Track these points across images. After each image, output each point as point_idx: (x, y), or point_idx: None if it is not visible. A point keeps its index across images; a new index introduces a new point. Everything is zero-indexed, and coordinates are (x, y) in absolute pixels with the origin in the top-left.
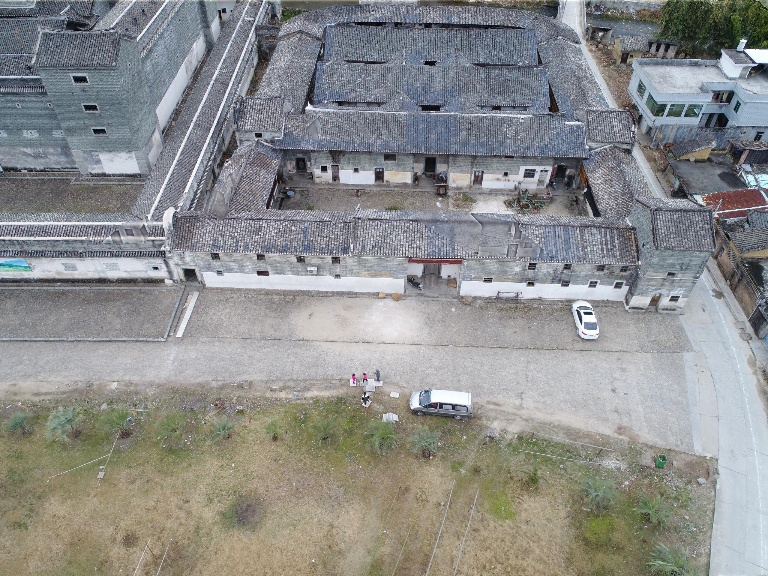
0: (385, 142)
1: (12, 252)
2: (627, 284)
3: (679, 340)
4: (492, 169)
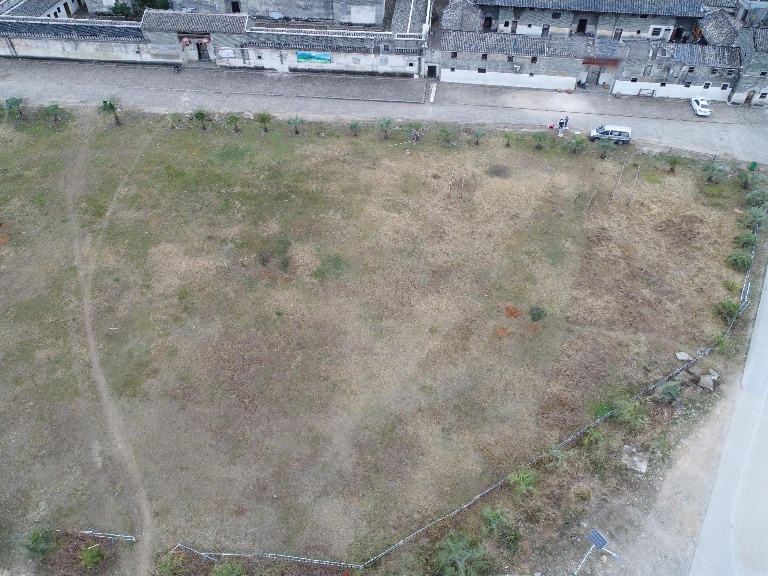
0: (555, 3)
1: (324, 47)
2: (731, 86)
3: (765, 120)
4: (629, 27)
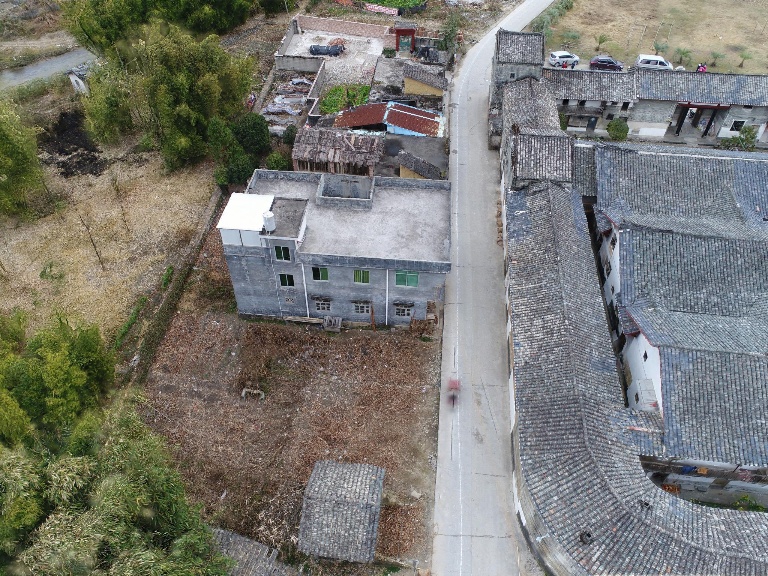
0: None
1: None
2: None
3: None
4: None
